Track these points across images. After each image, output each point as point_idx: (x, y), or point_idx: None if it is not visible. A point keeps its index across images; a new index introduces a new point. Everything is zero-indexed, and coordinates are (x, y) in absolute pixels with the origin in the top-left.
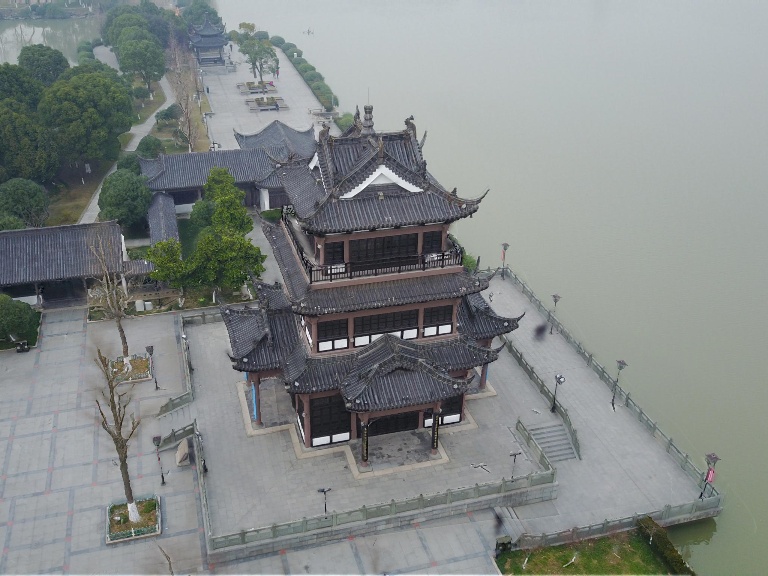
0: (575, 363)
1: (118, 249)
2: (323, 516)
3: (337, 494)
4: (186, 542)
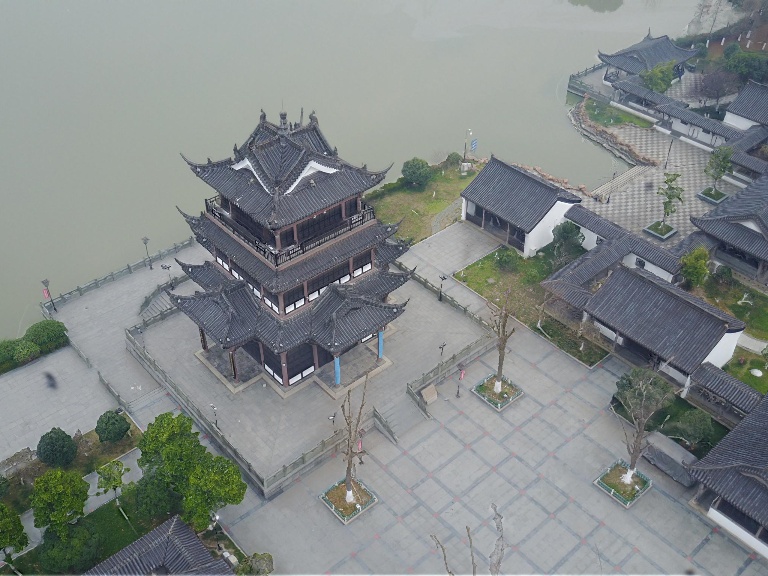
0: (193, 252)
1: (191, 573)
2: (444, 294)
3: (416, 304)
4: (493, 361)
